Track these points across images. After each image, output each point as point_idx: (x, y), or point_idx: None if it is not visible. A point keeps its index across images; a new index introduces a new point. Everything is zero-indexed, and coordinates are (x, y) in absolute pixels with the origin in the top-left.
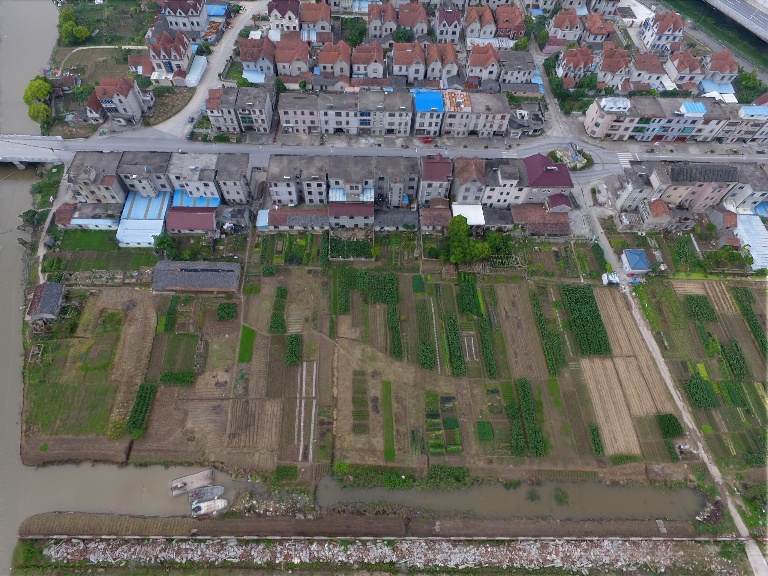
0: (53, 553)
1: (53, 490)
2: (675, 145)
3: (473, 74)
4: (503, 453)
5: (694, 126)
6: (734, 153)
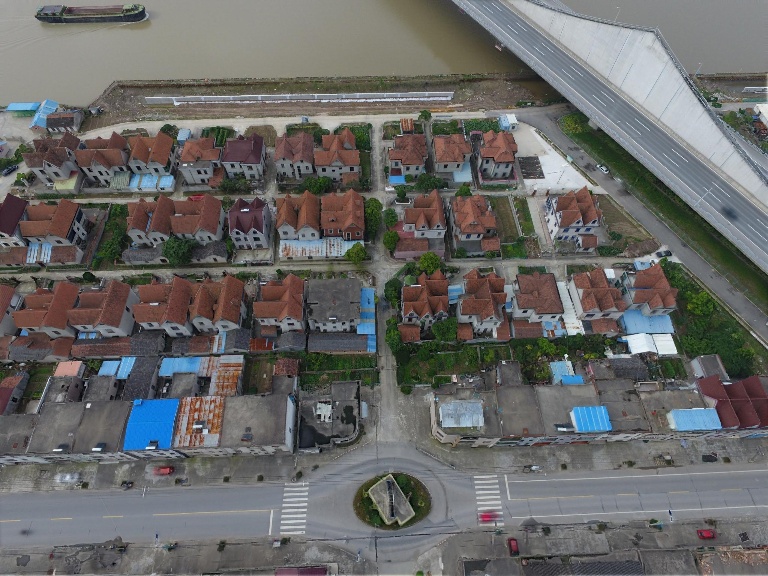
0: None
1: None
2: (571, 451)
3: (267, 323)
4: None
5: (596, 436)
6: (666, 464)
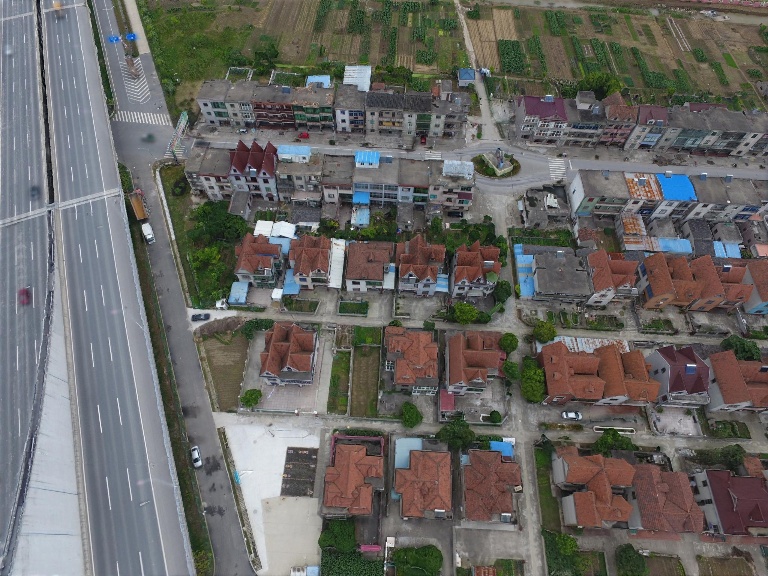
0: None
1: None
2: None
3: None
4: None
5: None
6: None
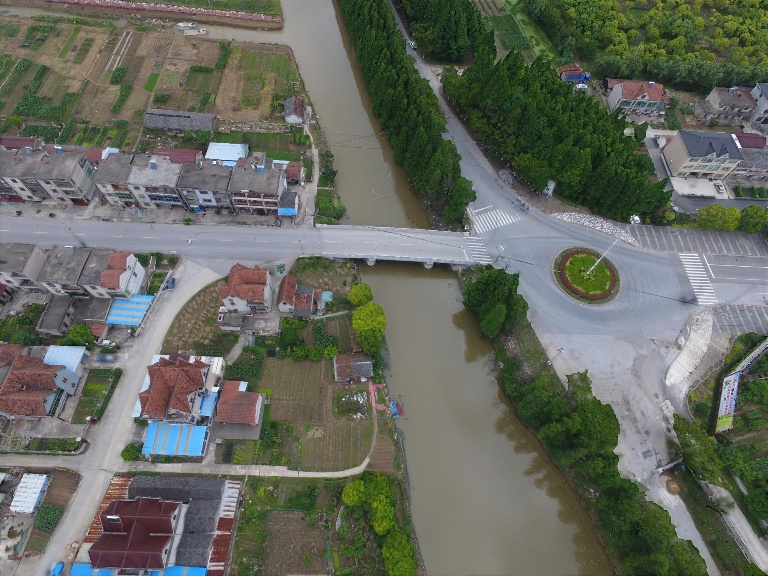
0: (262, 16)
1: (270, 37)
2: None
3: None
4: (7, 23)
5: None
6: None
